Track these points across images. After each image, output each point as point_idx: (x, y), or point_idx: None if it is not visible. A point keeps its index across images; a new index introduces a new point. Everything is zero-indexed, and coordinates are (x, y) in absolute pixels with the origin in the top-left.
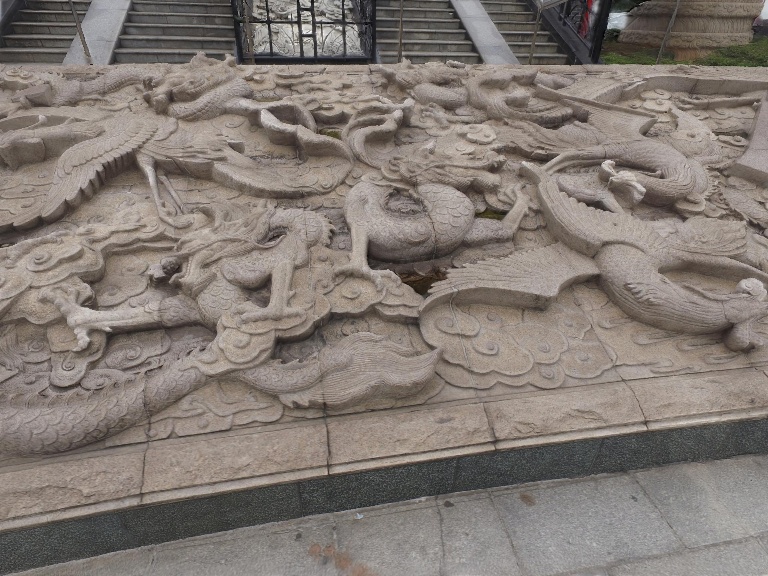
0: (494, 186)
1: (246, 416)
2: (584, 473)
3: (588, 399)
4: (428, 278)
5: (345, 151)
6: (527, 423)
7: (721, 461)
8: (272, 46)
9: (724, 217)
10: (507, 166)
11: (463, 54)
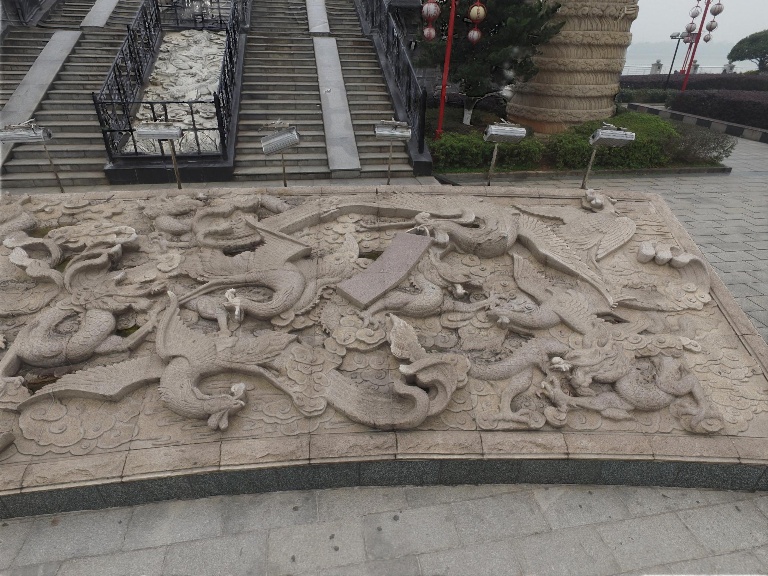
0: (141, 310)
1: None
2: (102, 507)
3: (89, 463)
4: None
5: None
6: (44, 477)
7: (199, 500)
8: (136, 148)
9: (313, 327)
10: (172, 290)
11: (312, 145)
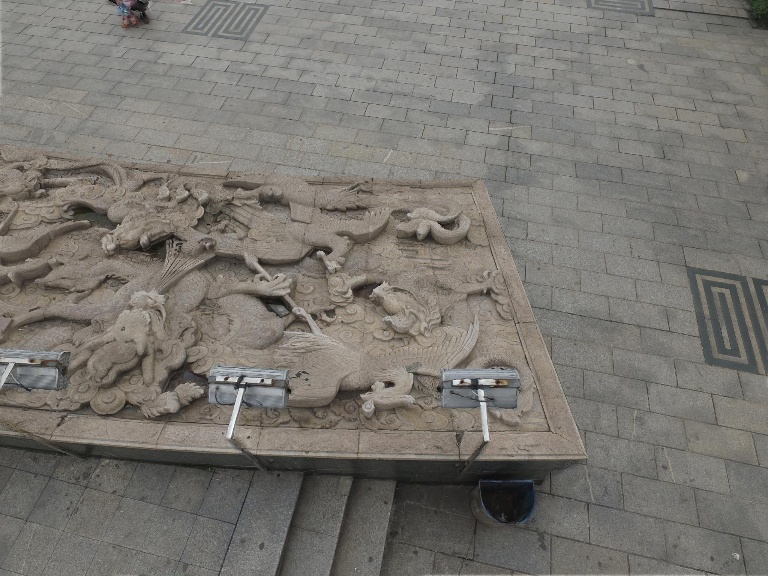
0: None
1: (58, 161)
2: None
3: None
4: None
5: None
6: None
7: None
8: None
9: None
10: None
11: None
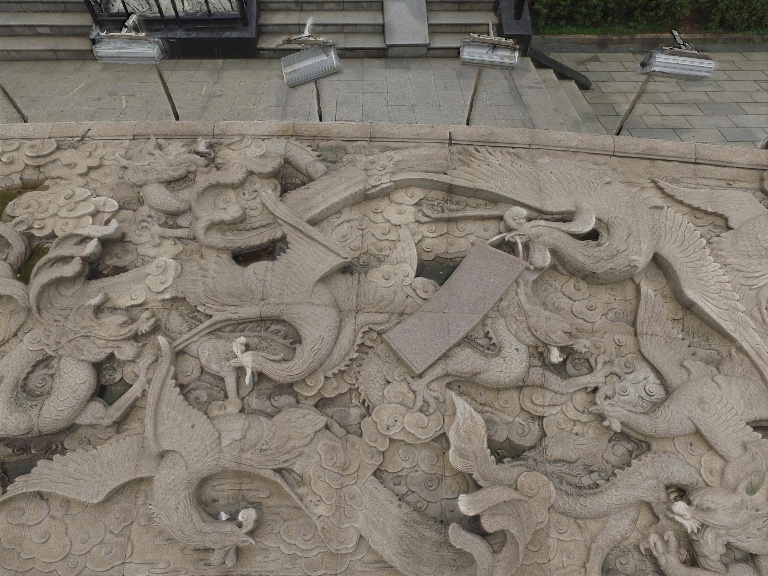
0: (127, 360)
1: None
2: None
3: None
4: (36, 457)
5: (19, 303)
6: None
7: None
8: (126, 6)
9: (348, 392)
10: (167, 322)
11: None
